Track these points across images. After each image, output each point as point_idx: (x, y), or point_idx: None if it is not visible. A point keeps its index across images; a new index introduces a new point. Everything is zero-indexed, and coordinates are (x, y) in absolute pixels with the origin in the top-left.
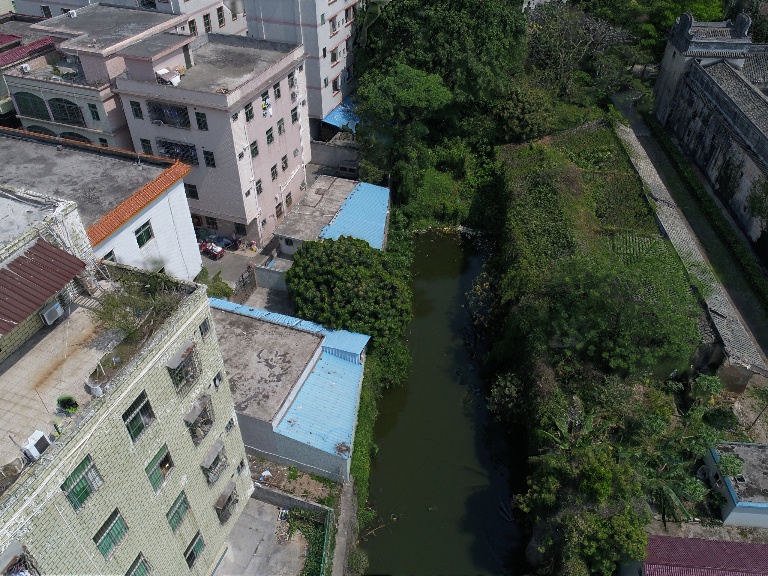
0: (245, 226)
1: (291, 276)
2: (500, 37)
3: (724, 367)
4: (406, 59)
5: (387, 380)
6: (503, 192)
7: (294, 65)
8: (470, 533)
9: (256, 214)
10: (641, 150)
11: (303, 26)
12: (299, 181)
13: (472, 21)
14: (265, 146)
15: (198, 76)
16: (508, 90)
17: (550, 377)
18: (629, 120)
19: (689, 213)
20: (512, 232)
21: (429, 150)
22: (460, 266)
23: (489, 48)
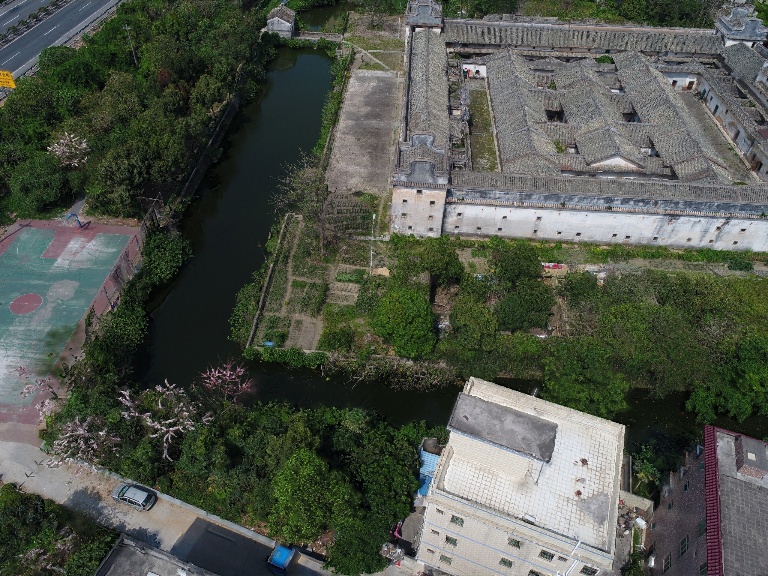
0: None
1: None
2: None
3: None
4: None
5: None
6: None
7: None
8: None
9: None
10: None
11: None
12: None
13: None
14: None
15: None
16: None
17: (472, 2)
18: None
19: None
20: None
21: None
22: None
23: None
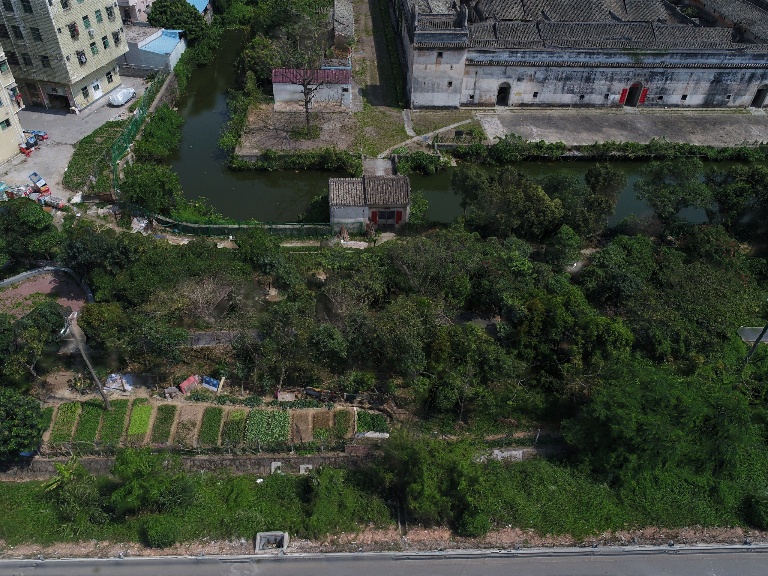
0: (129, 12)
1: (149, 14)
2: None
3: (335, 37)
4: None
5: (198, 61)
6: None
7: None
8: (225, 95)
9: (134, 3)
10: None
11: None
12: None
13: None
14: None
15: None
16: None
17: None
18: None
19: (374, 17)
20: None
21: None
22: None
23: None
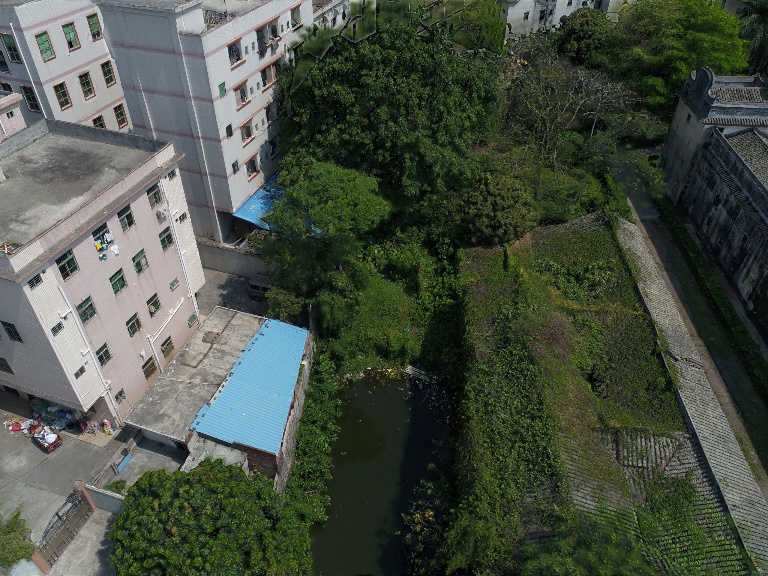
0: None
1: (115, 539)
2: (464, 107)
3: None
4: (339, 139)
5: None
6: (463, 339)
7: (154, 177)
8: None
9: (102, 391)
10: (651, 263)
11: (195, 100)
12: (185, 316)
13: (425, 90)
14: (110, 297)
15: (0, 203)
16: (476, 175)
17: None
18: (631, 195)
19: (716, 349)
20: (469, 427)
21: (376, 246)
22: (404, 440)
23: (448, 125)
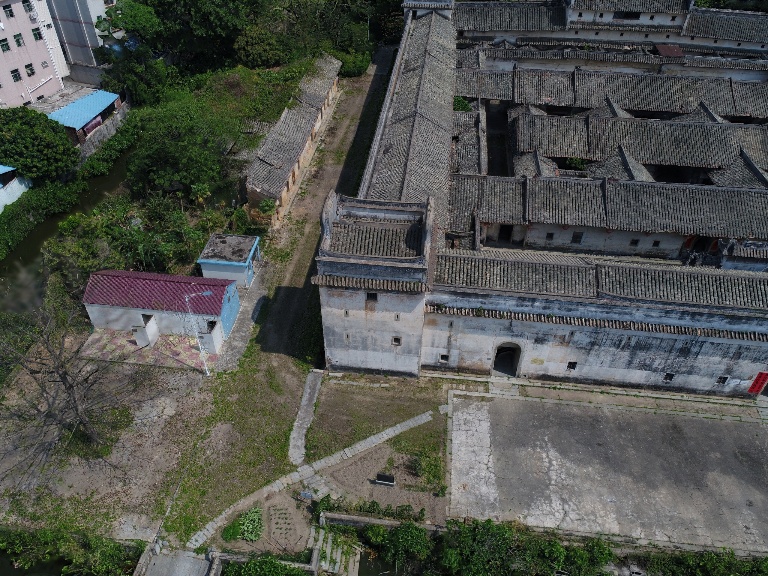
0: None
1: None
2: None
3: (248, 192)
4: (158, 1)
5: (47, 209)
6: None
7: None
8: None
9: None
10: (331, 74)
11: None
12: (55, 89)
13: None
14: None
15: None
16: None
17: (119, 192)
18: (380, 64)
19: (363, 123)
20: None
21: None
22: None
23: None
